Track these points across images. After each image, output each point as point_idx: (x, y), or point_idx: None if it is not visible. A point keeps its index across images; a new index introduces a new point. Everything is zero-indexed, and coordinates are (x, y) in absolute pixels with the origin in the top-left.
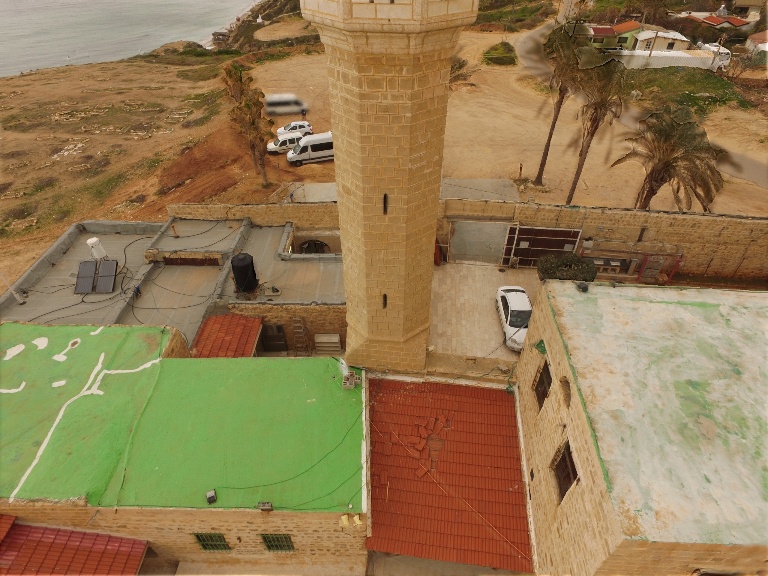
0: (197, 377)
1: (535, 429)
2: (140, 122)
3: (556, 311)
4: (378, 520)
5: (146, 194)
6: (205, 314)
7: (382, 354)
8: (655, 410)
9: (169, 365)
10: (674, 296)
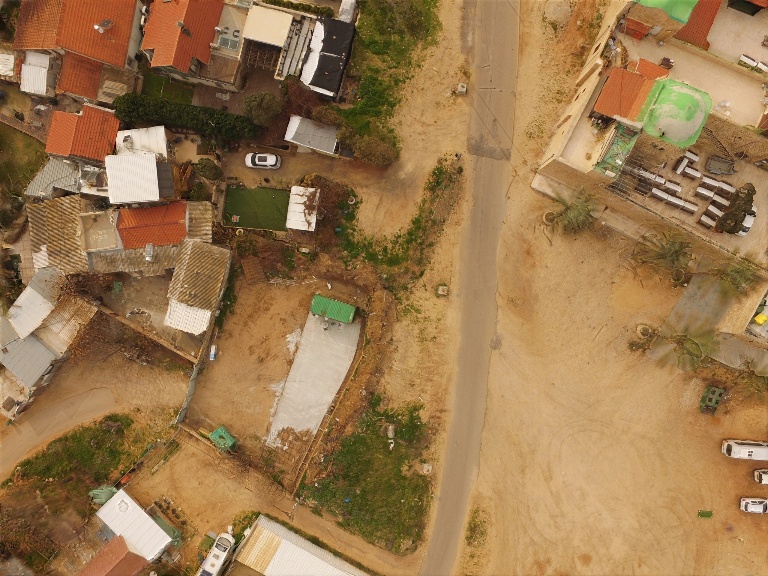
0: None
1: None
2: None
3: None
4: None
5: None
6: None
7: None
8: None
9: None
10: None
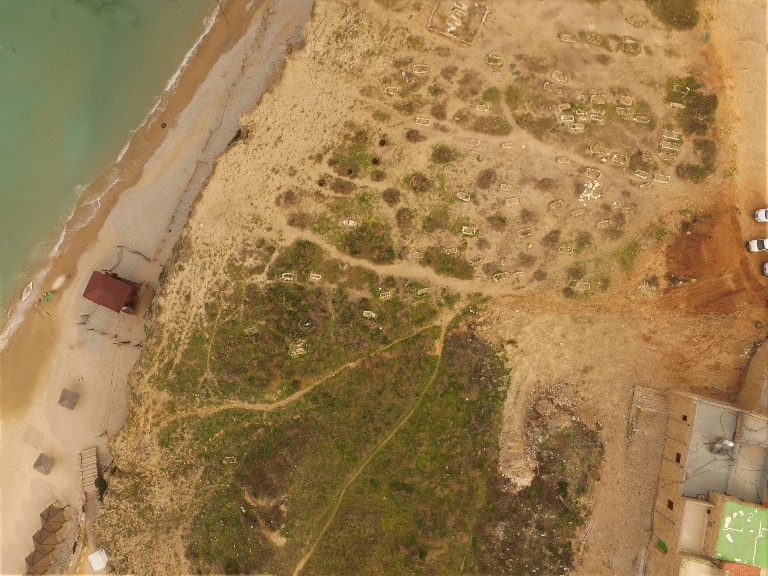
0: None
1: None
2: (637, 149)
3: None
4: None
5: (658, 276)
6: (767, 485)
7: None
8: None
9: None
10: None
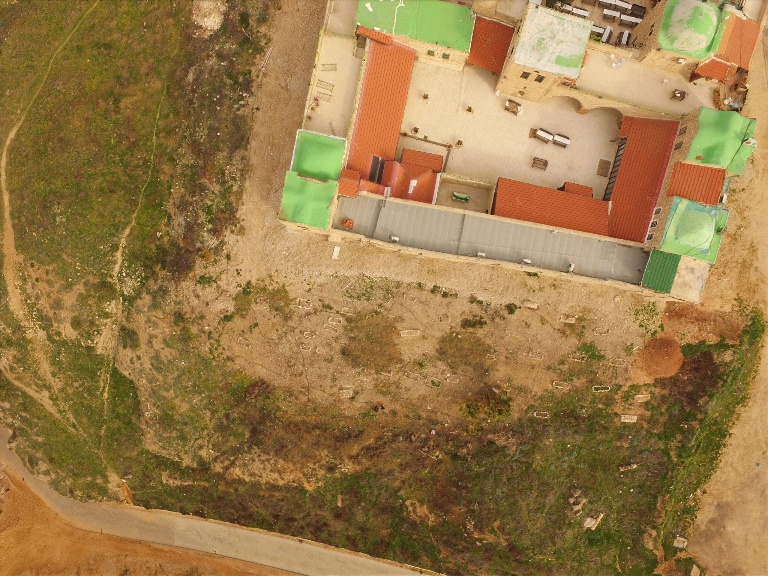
0: (430, 6)
1: (513, 41)
2: None
3: (527, 13)
4: (470, 56)
5: None
6: None
7: (483, 10)
8: (531, 42)
9: None
10: (557, 14)
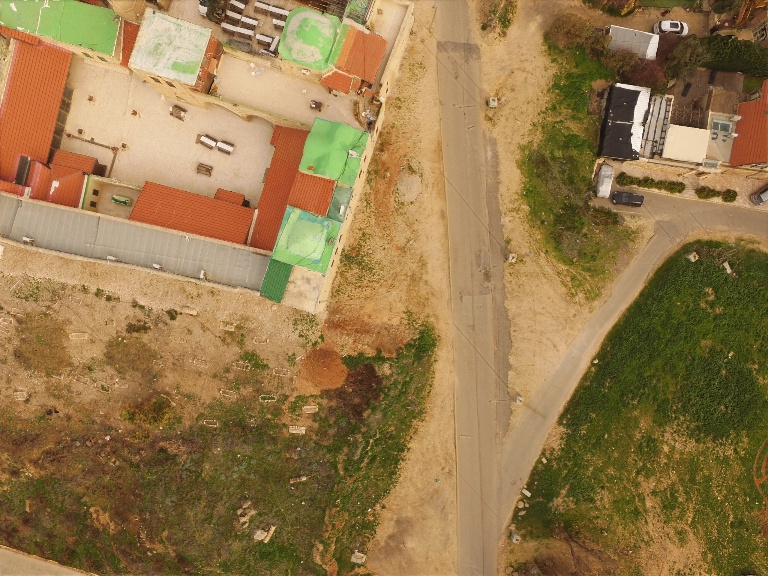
0: (74, 8)
1: None
2: None
3: (144, 18)
4: (123, 59)
5: None
6: None
7: (123, 14)
8: (148, 47)
9: (66, 1)
10: (174, 21)
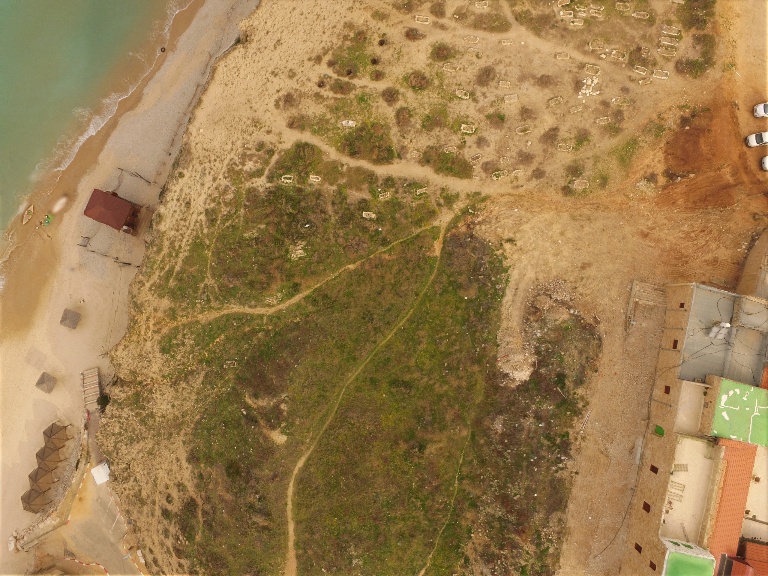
0: None
1: None
2: (637, 45)
3: None
4: None
5: (656, 172)
6: (764, 368)
7: None
8: None
9: None
10: None
